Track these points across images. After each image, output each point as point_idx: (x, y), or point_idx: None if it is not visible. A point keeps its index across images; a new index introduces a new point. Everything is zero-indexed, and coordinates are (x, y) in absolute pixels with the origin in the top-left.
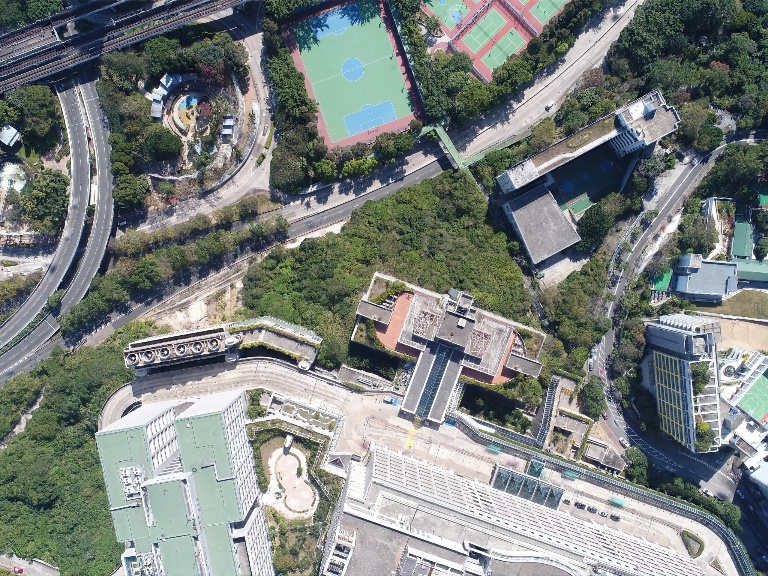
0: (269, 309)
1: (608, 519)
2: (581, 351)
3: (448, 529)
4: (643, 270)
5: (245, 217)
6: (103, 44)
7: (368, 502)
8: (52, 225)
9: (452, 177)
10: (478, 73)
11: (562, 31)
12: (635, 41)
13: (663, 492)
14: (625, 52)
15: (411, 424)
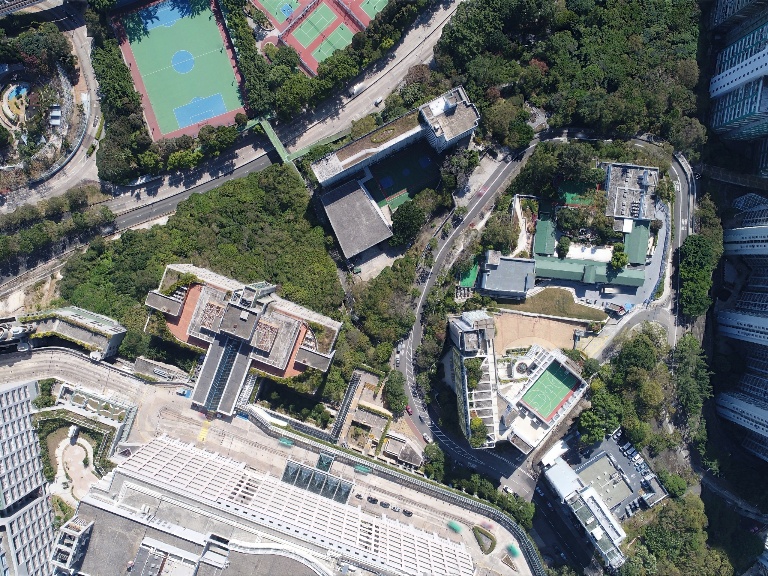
0: (80, 300)
1: (401, 514)
2: (384, 346)
3: (193, 520)
4: (451, 266)
5: (75, 208)
6: None
7: (113, 492)
8: None
9: None
10: (308, 67)
11: (385, 27)
12: (456, 38)
13: (460, 488)
14: (448, 49)
15: (204, 416)
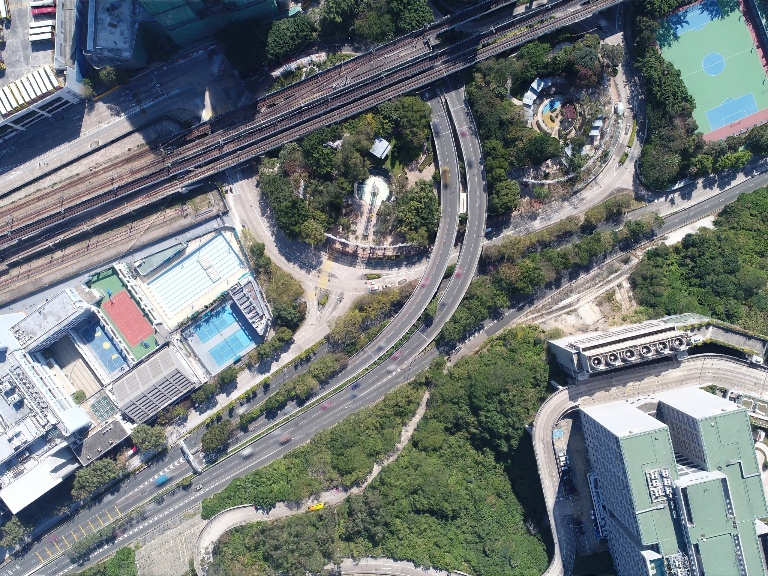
0: (678, 306)
1: None
2: None
3: None
4: None
5: (610, 217)
6: (477, 52)
7: None
8: (427, 235)
9: None
10: None
11: None
12: None
13: None
14: None
15: None
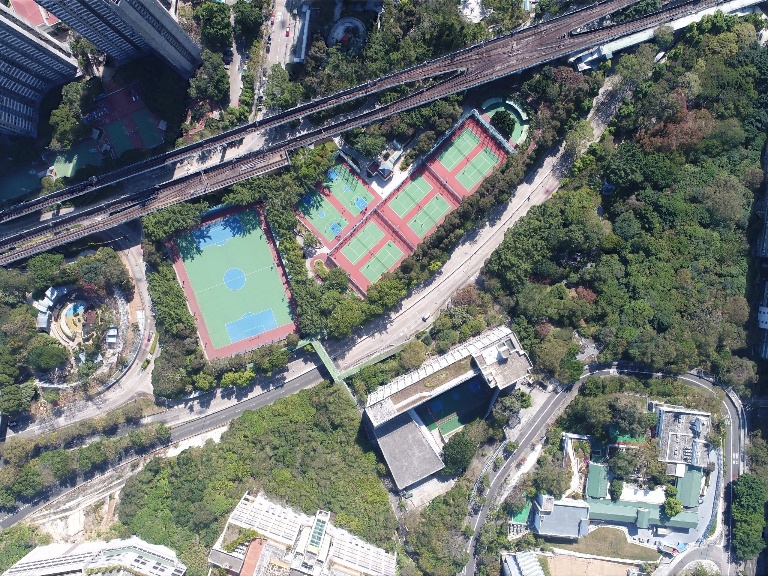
0: (140, 530)
1: None
2: None
3: None
4: (504, 501)
5: (130, 420)
6: None
7: None
8: None
9: (330, 387)
10: (356, 284)
11: (433, 253)
12: (504, 265)
13: None
14: (496, 273)
15: None
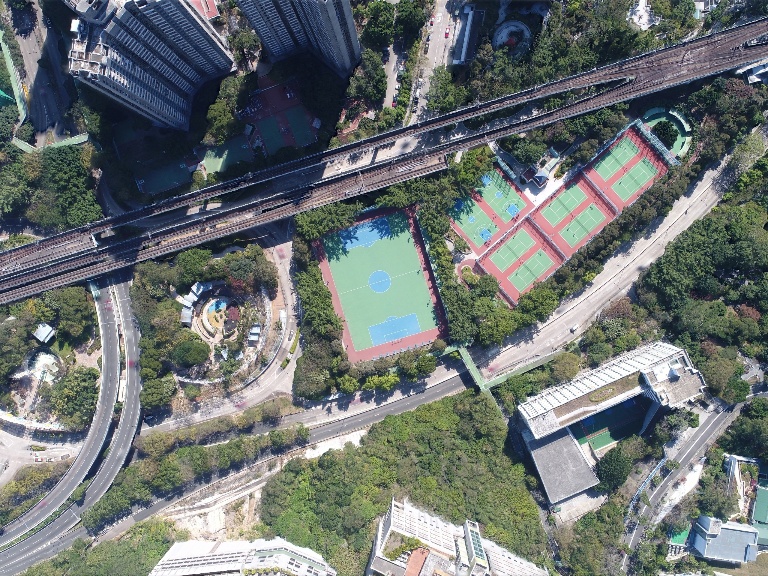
0: (286, 532)
1: None
2: None
3: None
4: (661, 521)
5: (267, 418)
6: (138, 252)
7: None
8: (81, 421)
9: (473, 395)
10: (504, 292)
11: (590, 263)
12: (664, 279)
13: None
14: (654, 287)
15: None
